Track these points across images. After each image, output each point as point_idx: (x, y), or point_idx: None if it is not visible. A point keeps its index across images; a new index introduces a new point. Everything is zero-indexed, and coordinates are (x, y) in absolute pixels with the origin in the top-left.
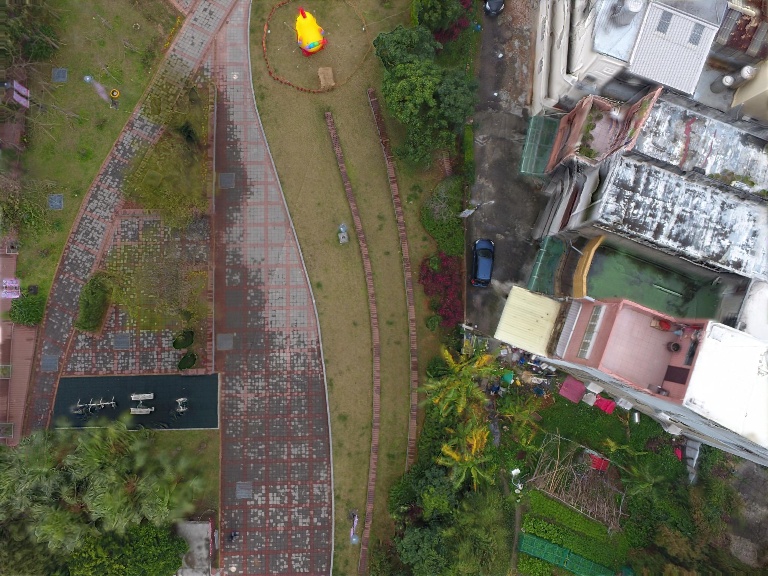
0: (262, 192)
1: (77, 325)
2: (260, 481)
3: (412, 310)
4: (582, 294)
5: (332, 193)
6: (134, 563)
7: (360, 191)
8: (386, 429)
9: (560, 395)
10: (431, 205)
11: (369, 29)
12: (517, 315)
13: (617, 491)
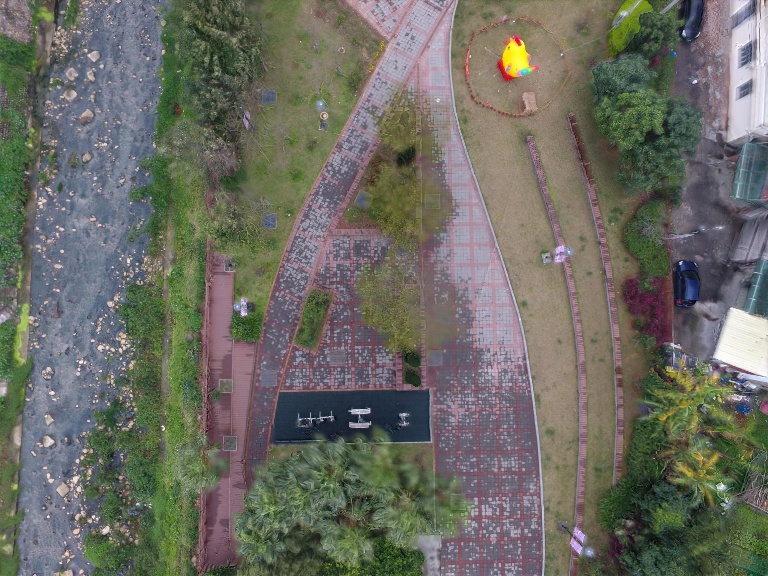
0: (467, 213)
1: (302, 342)
2: (473, 493)
3: (617, 329)
4: None
5: (535, 214)
6: (382, 573)
7: (563, 213)
8: (593, 443)
9: (760, 412)
10: (637, 227)
11: (568, 55)
12: (736, 336)
13: None
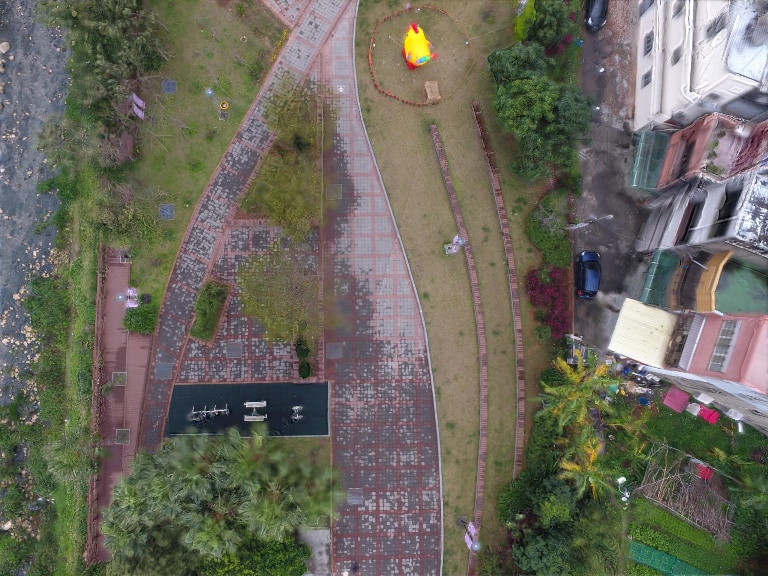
0: (369, 203)
1: (194, 334)
2: (370, 488)
3: (519, 320)
4: (710, 308)
5: (438, 205)
6: (263, 568)
7: (466, 203)
8: (493, 437)
9: (664, 405)
10: (538, 217)
11: (473, 43)
12: (631, 327)
13: (723, 499)
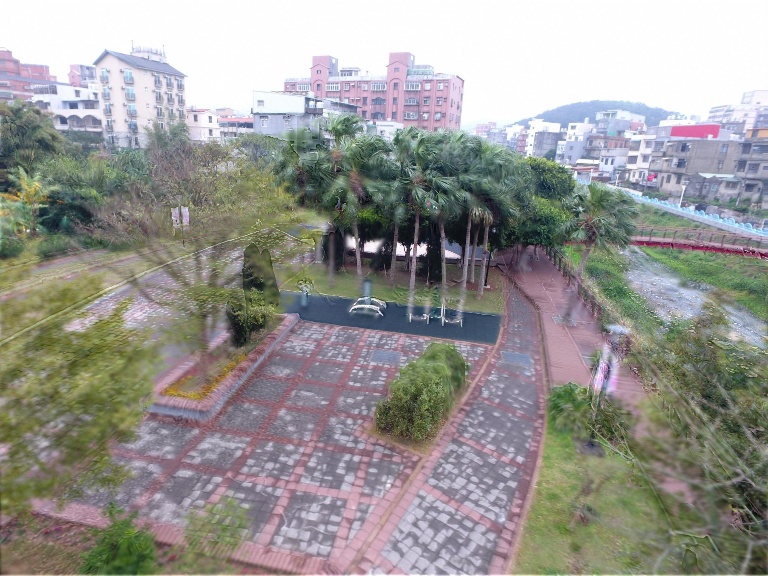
0: None
1: None
2: None
3: None
4: None
5: None
6: None
7: None
8: (86, 261)
9: None
10: None
11: None
12: None
13: None
